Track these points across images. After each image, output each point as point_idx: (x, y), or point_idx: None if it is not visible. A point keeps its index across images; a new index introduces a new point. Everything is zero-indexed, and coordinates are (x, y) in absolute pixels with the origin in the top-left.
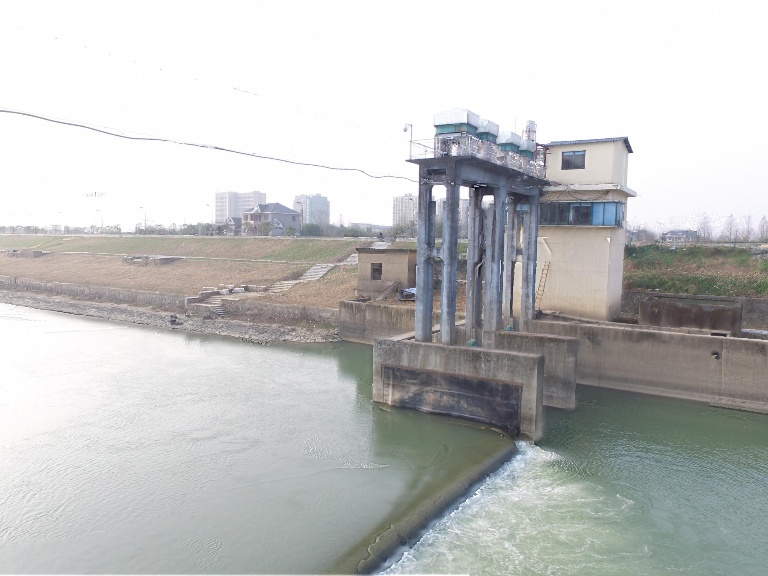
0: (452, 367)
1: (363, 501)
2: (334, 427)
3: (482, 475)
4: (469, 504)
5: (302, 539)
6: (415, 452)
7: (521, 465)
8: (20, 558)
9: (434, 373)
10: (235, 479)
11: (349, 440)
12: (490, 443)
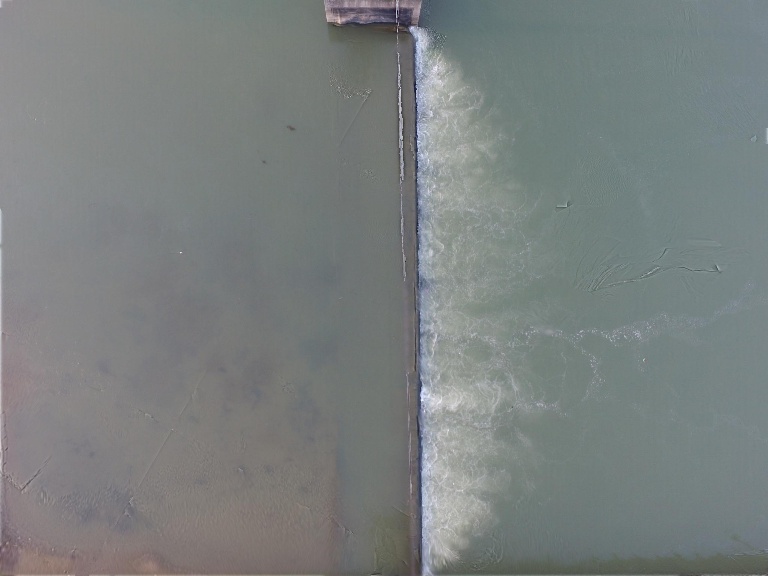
0: (375, 5)
1: (389, 122)
2: (327, 59)
3: (414, 76)
4: (418, 98)
5: (389, 155)
6: (357, 38)
7: (420, 52)
8: (327, 208)
9: (365, 8)
10: (337, 133)
11: (345, 71)
12: (403, 42)
